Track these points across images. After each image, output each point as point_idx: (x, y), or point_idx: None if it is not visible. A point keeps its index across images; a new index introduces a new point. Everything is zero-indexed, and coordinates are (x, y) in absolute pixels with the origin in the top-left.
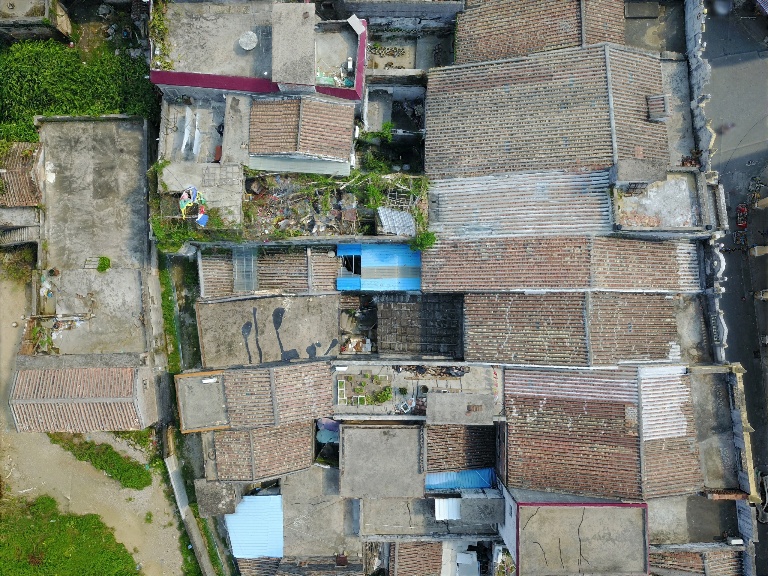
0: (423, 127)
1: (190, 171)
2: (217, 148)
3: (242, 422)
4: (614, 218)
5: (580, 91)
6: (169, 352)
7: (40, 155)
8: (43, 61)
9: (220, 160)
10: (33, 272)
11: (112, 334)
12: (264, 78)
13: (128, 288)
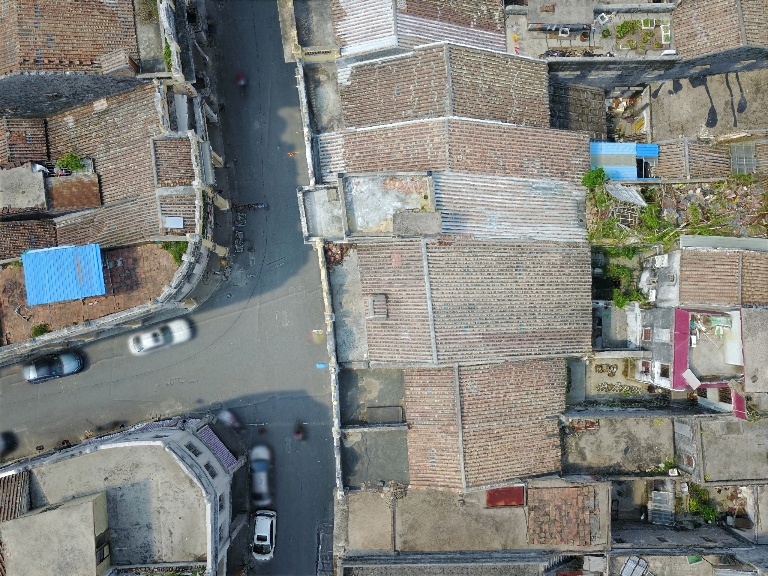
0: None
1: None
2: None
3: None
4: None
5: (458, 320)
6: None
7: None
8: None
9: None
10: None
11: None
12: None
13: None
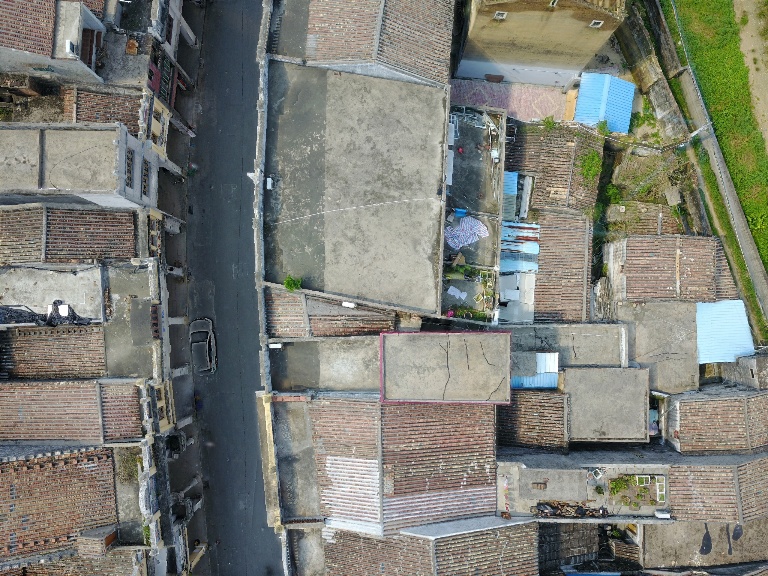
0: None
1: None
2: None
3: (764, 463)
4: None
5: None
6: None
7: None
8: None
9: None
10: None
11: None
12: None
13: None
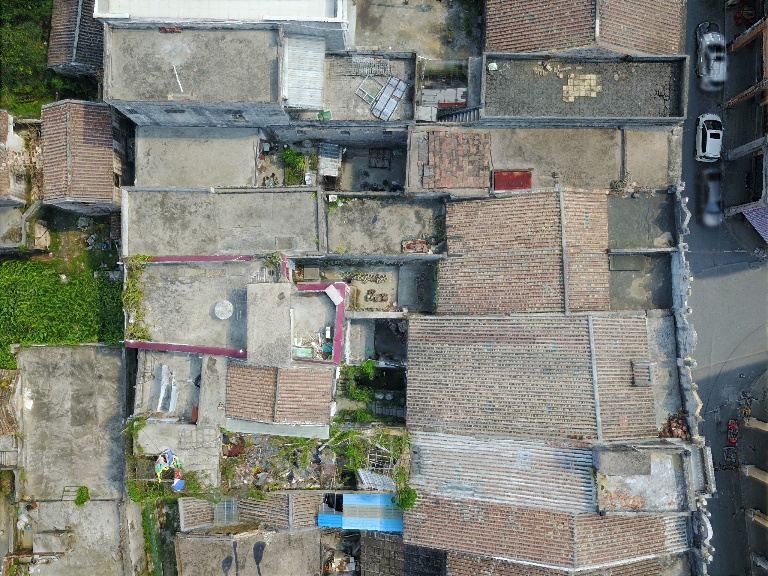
0: (406, 355)
1: (166, 433)
2: (193, 409)
3: None
4: (598, 500)
5: (563, 358)
6: (150, 570)
7: (17, 384)
8: (20, 291)
9: (196, 422)
10: (10, 508)
11: (90, 568)
12: (240, 349)
13: (106, 521)
